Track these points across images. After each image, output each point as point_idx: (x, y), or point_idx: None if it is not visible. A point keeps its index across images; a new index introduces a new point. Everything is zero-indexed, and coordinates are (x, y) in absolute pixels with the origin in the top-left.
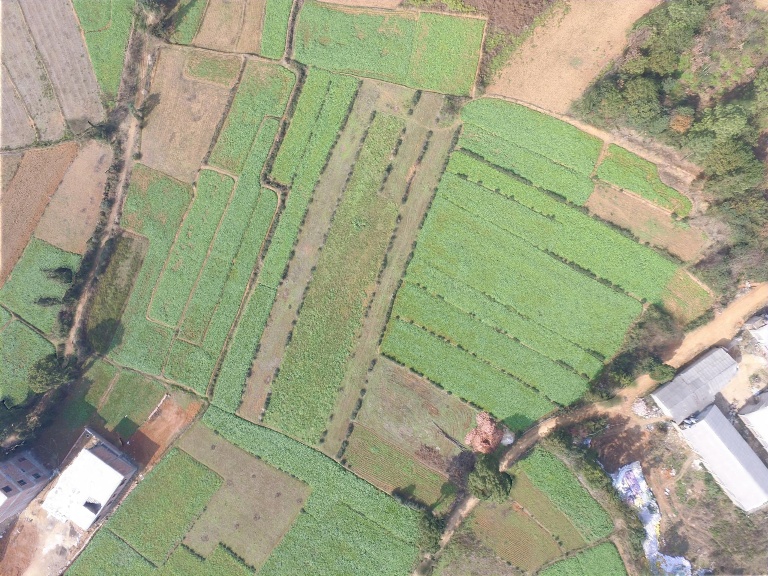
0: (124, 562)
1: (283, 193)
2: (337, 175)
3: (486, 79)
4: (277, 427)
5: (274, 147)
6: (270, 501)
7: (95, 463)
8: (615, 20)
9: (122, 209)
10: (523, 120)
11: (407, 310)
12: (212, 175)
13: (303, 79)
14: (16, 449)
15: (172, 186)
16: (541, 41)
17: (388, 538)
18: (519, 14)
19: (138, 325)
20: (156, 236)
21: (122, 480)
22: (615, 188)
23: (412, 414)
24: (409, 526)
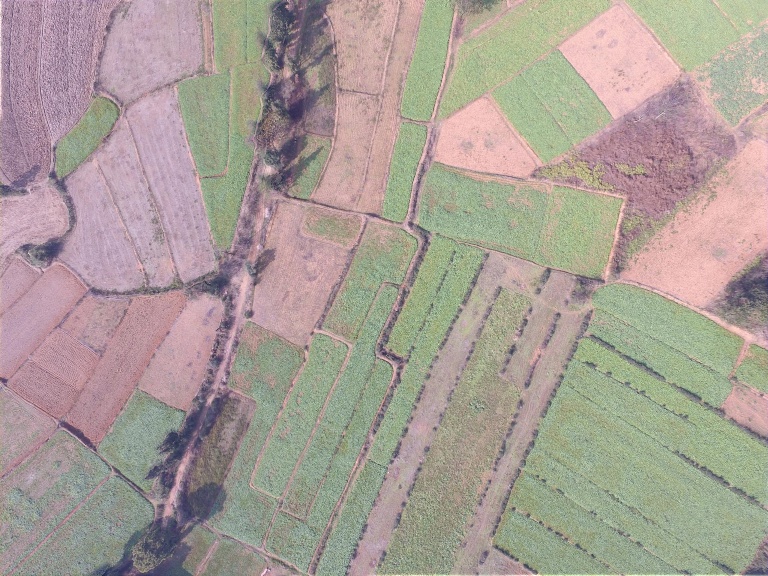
0: None
1: (399, 366)
2: (457, 352)
3: (621, 263)
4: None
5: (392, 316)
6: None
7: None
8: (764, 212)
9: (230, 368)
10: (659, 311)
11: (524, 502)
12: (325, 340)
13: (426, 246)
14: None
15: (283, 348)
16: (682, 227)
17: None
18: (661, 198)
19: (241, 492)
20: (264, 400)
21: None
22: (755, 392)
23: None
24: None
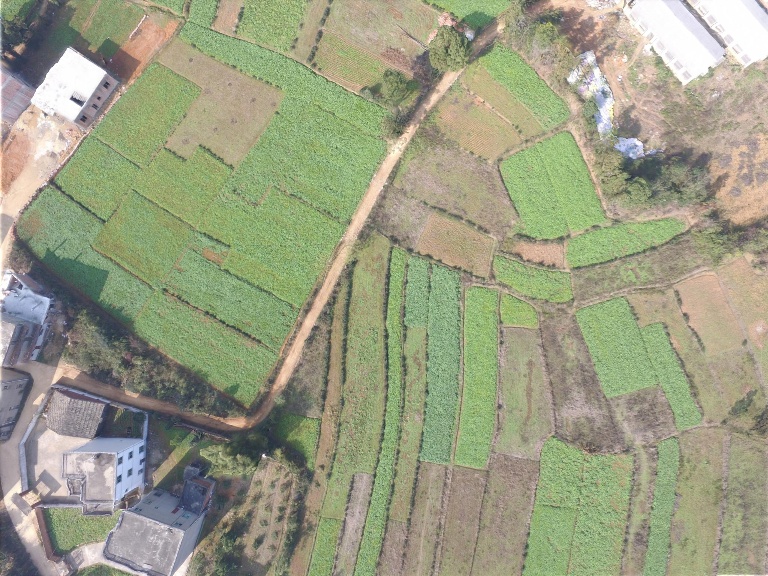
0: (111, 165)
1: None
2: None
3: None
4: (250, 38)
5: None
6: (246, 106)
7: (79, 60)
8: None
9: None
10: None
11: None
12: None
13: None
14: (5, 60)
15: None
16: None
17: (357, 134)
18: None
19: None
20: None
21: (105, 77)
22: None
23: (377, 19)
24: (377, 121)
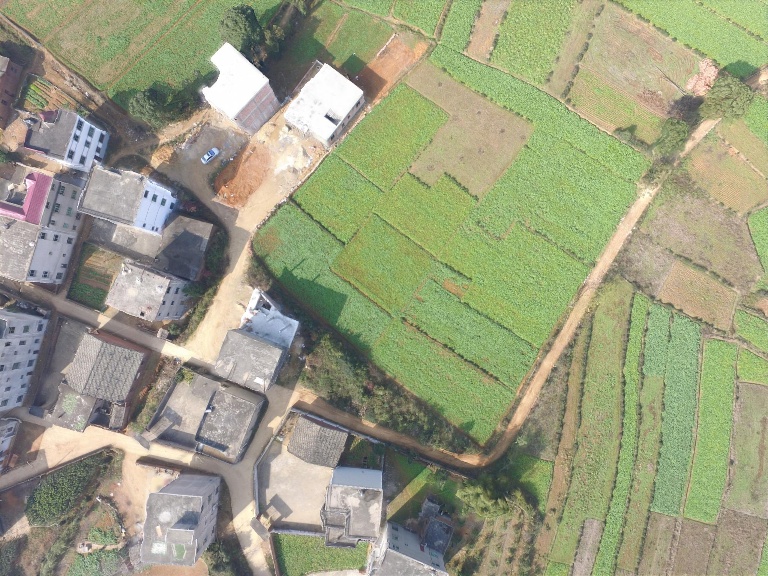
0: (352, 186)
1: None
2: None
3: None
4: (504, 67)
5: None
6: (494, 137)
7: (337, 77)
8: None
9: None
10: None
11: None
12: None
13: None
14: None
15: None
16: None
17: (608, 175)
18: None
19: None
20: None
21: (361, 96)
22: None
23: (636, 59)
24: (629, 164)
